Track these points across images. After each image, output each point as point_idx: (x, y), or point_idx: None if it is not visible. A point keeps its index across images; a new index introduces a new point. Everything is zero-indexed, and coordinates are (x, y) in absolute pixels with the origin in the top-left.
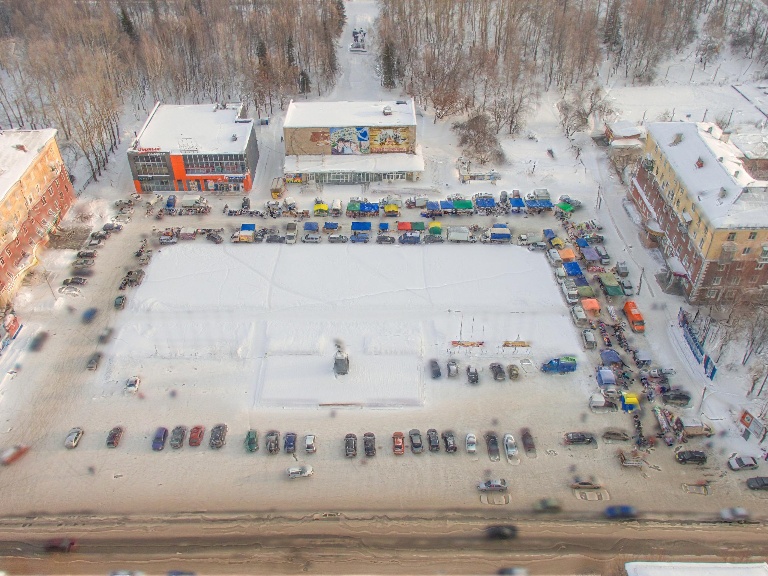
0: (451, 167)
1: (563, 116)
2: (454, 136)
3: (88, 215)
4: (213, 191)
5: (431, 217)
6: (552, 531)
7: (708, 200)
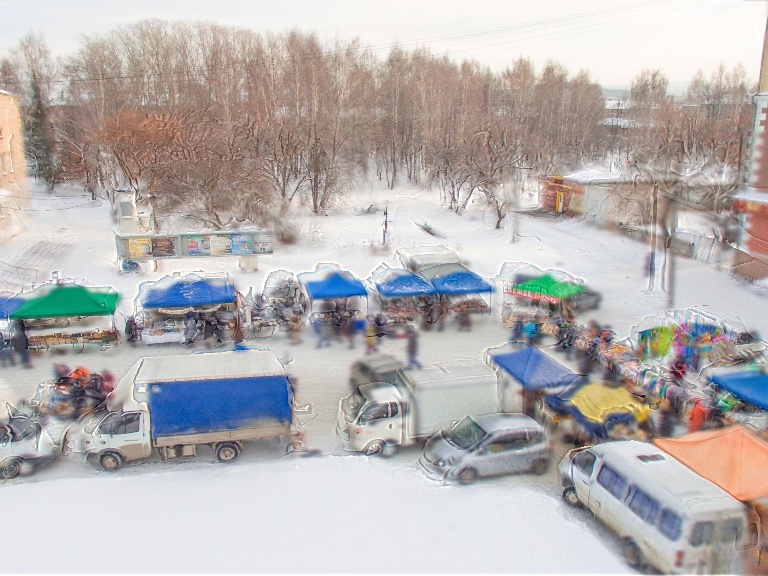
0: None
1: None
2: None
3: None
4: None
5: None
6: None
7: None
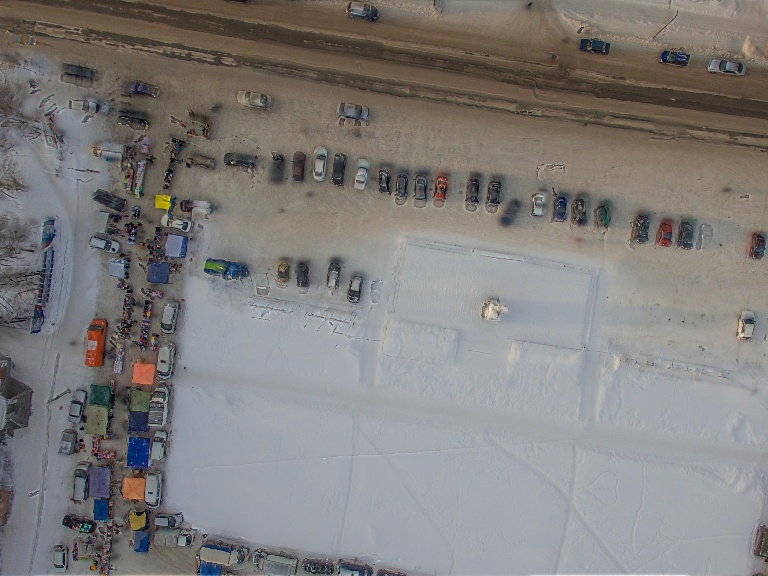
0: None
1: None
2: None
3: None
4: None
5: None
6: (310, 66)
7: None
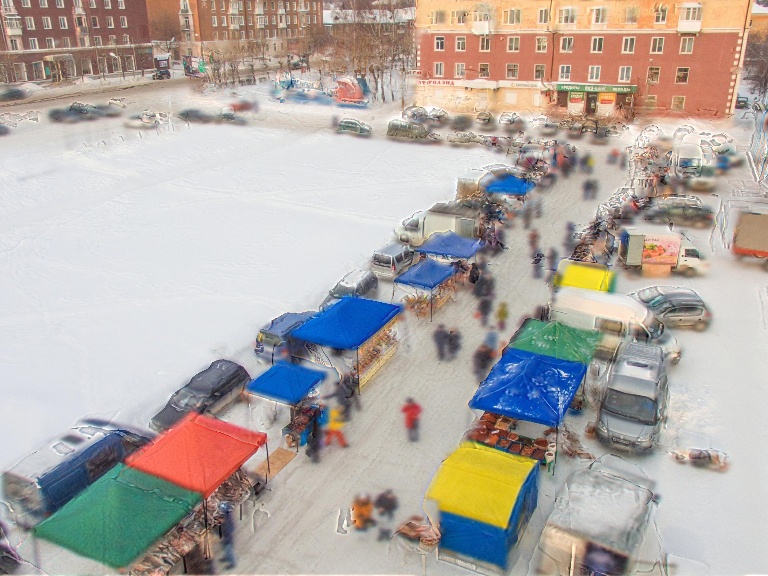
0: None
1: None
2: None
3: (634, 115)
4: None
5: None
6: None
7: None
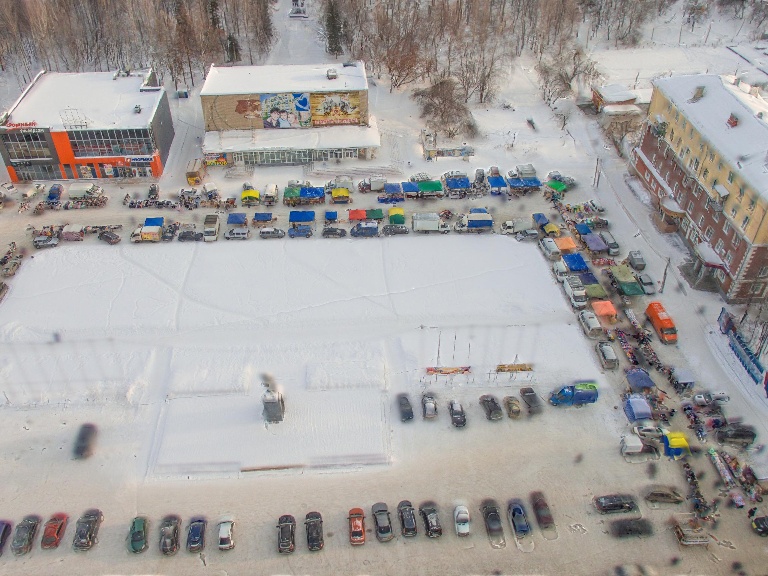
0: (413, 142)
1: (542, 81)
2: (415, 106)
3: None
4: (112, 178)
5: (391, 203)
6: None
7: (752, 166)
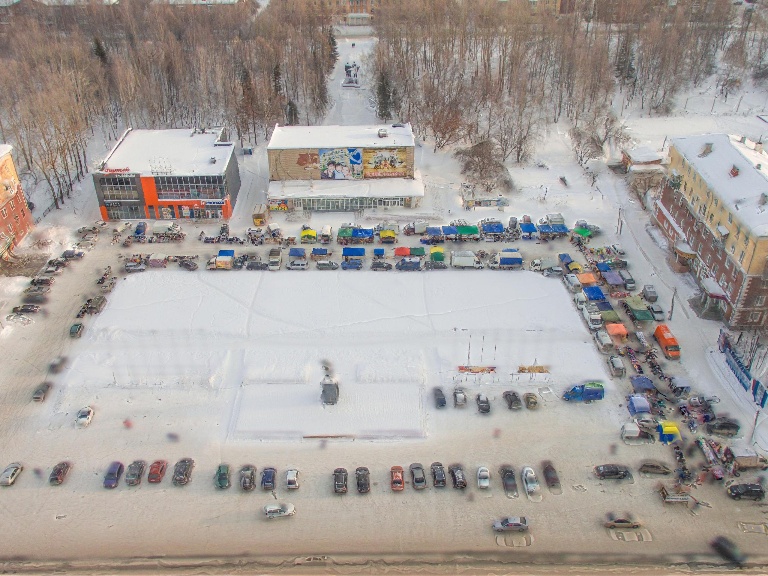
0: (453, 194)
1: (575, 143)
2: (456, 163)
3: (46, 242)
4: (188, 219)
5: (432, 243)
6: None
7: (747, 208)
